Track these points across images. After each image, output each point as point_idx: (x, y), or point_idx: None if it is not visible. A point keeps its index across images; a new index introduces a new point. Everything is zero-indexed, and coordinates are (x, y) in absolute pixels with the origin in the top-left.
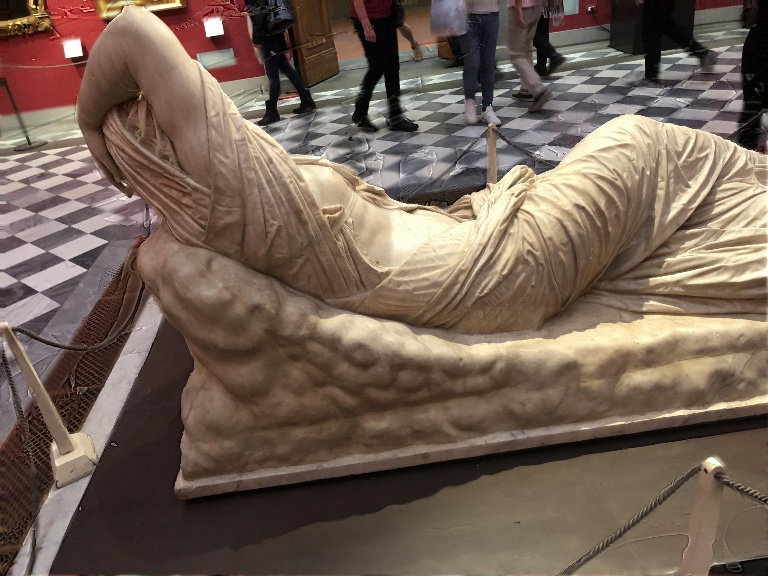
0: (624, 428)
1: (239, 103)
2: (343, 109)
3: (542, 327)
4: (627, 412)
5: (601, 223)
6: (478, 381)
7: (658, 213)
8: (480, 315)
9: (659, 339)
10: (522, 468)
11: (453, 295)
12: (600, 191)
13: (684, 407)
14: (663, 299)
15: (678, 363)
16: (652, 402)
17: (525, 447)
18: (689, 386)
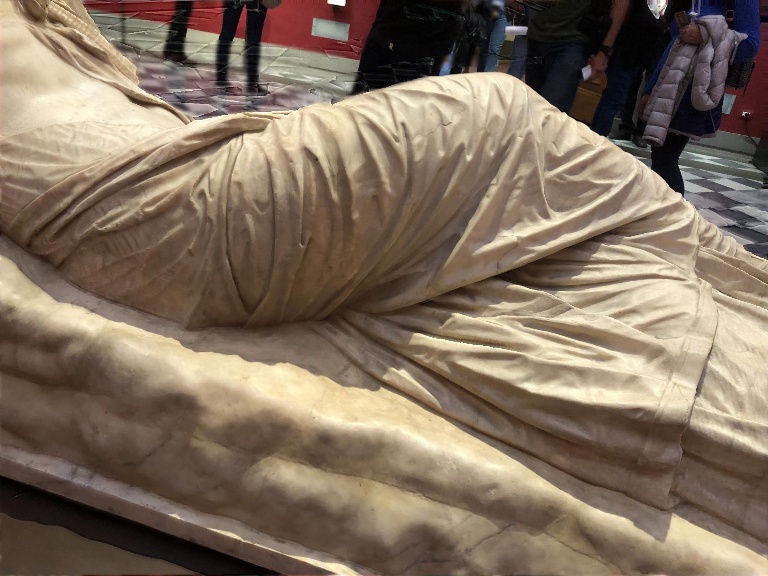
0: (239, 547)
1: (204, 4)
2: (324, 58)
3: (199, 329)
4: (257, 524)
5: (340, 197)
6: (35, 358)
7: (466, 232)
8: (97, 263)
9: (352, 426)
10: (61, 531)
11: (58, 210)
12: (360, 146)
13: (352, 562)
14: (421, 374)
15: (368, 482)
16: (298, 526)
17: (85, 501)
18: (368, 530)
